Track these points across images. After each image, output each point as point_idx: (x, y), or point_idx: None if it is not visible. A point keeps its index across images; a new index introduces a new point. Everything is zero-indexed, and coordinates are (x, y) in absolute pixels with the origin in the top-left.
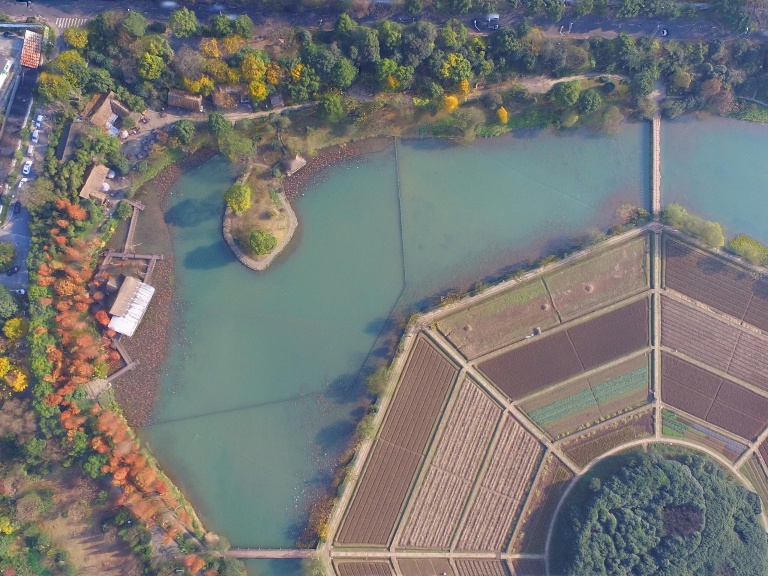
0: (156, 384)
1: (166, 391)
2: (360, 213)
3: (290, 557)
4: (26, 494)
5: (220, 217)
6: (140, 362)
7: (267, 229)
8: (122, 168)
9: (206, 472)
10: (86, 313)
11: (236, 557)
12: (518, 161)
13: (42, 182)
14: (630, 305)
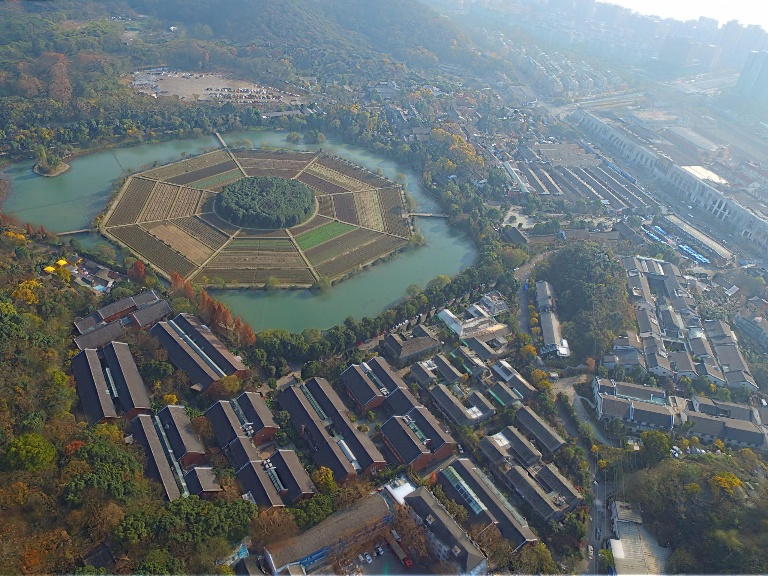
0: None
1: (8, 206)
2: (99, 162)
3: (83, 231)
4: None
5: None
6: None
7: None
8: None
9: (32, 221)
10: None
11: None
12: (165, 146)
13: None
14: (225, 162)
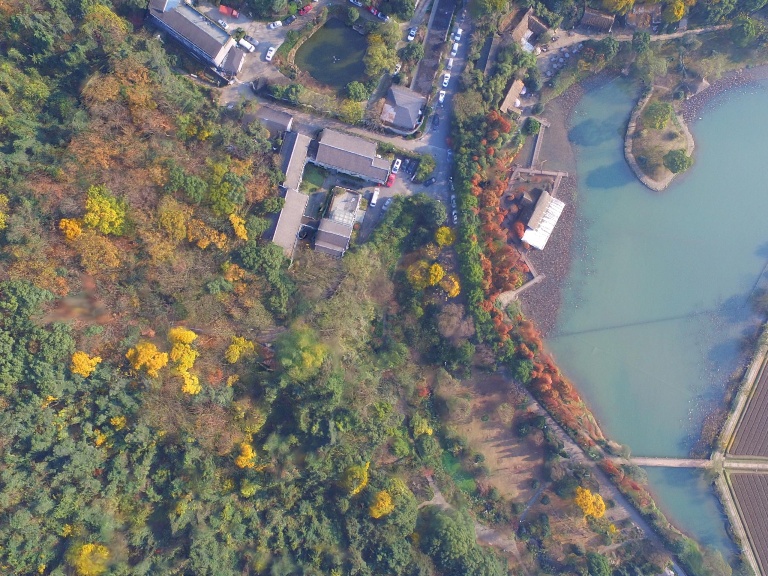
0: (559, 297)
1: (569, 304)
2: (752, 138)
3: (686, 466)
4: (448, 397)
5: (621, 137)
6: (545, 276)
7: (668, 150)
8: (539, 84)
9: (605, 384)
10: (499, 226)
11: (637, 464)
12: None
13: (473, 93)
14: None
